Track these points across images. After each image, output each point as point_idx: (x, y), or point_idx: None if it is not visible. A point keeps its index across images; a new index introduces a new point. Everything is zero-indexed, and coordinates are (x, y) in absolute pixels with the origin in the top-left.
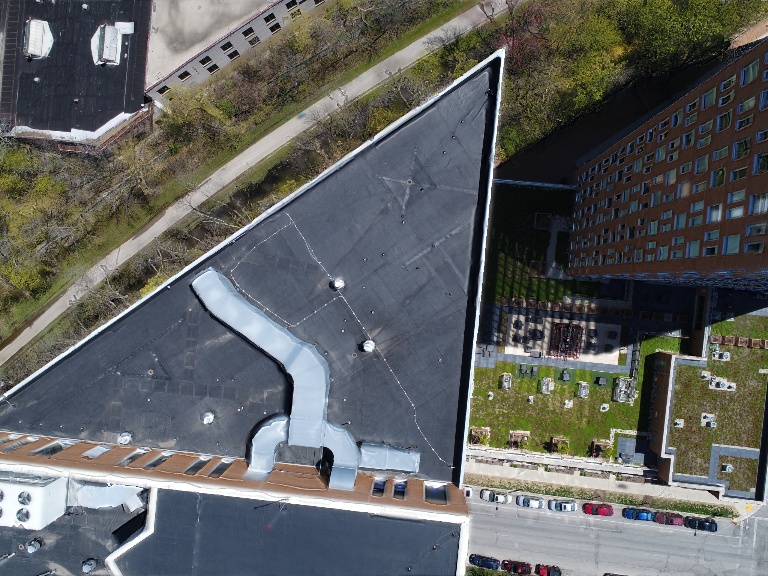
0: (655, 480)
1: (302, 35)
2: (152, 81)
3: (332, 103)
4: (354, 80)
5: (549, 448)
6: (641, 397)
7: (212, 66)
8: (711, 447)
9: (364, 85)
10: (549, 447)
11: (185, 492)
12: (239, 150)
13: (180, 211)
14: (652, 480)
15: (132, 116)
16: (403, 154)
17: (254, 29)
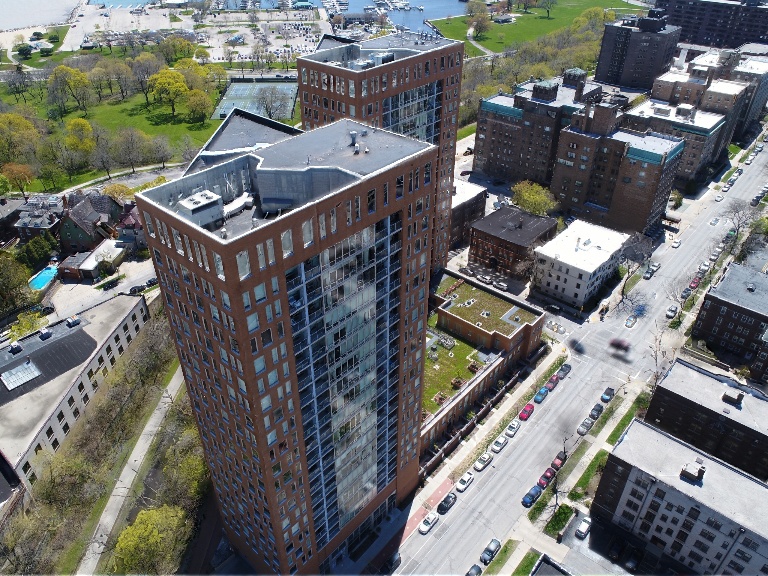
0: (523, 378)
1: (108, 387)
2: (16, 461)
3: (155, 421)
4: (159, 403)
5: (457, 388)
6: (457, 339)
7: (54, 441)
8: (501, 319)
9: (168, 400)
10: (456, 388)
11: (261, 150)
12: (109, 492)
13: (90, 565)
14: (522, 379)
15: (8, 500)
16: (232, 130)
17: (74, 399)
